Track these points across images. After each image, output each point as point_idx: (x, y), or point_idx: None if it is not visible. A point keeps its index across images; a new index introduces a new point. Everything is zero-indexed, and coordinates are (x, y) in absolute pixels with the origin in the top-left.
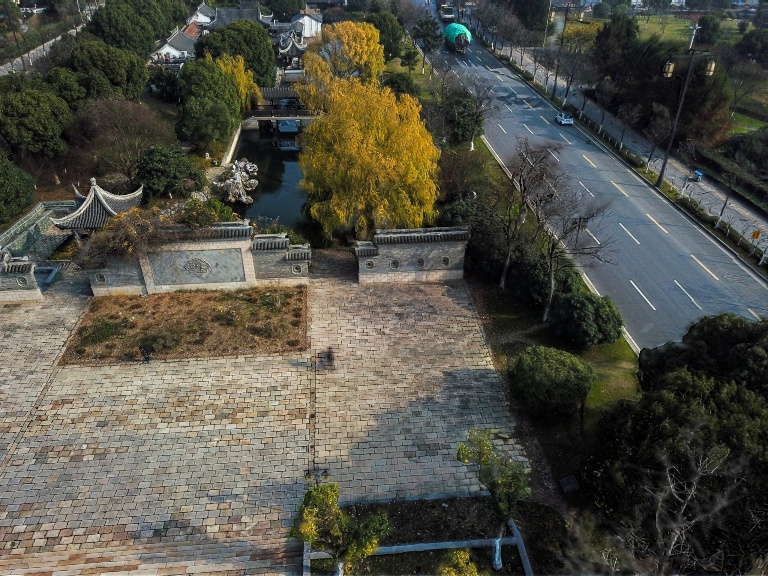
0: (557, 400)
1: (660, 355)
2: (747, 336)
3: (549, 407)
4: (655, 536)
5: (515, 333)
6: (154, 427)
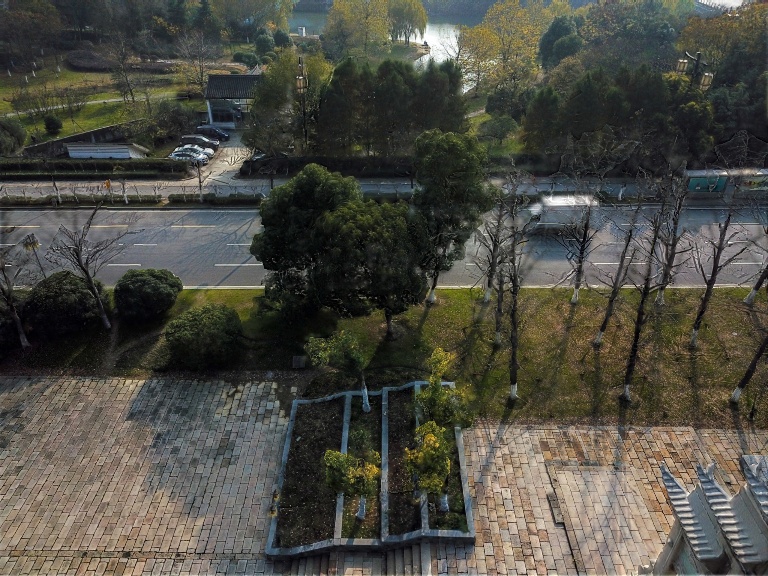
0: (235, 332)
1: (273, 238)
2: (309, 186)
3: (233, 343)
4: (419, 283)
5: (110, 352)
6: None
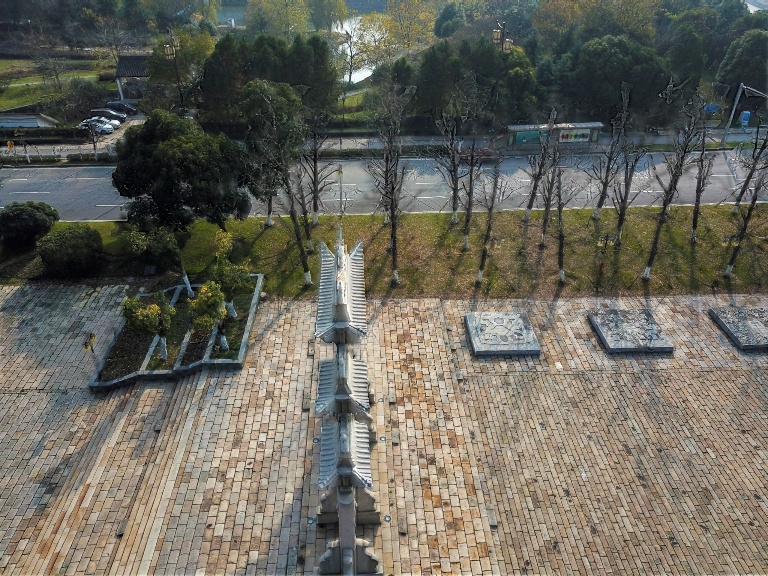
0: (94, 246)
1: (124, 169)
2: (153, 126)
3: (93, 255)
4: (231, 195)
5: None
6: None
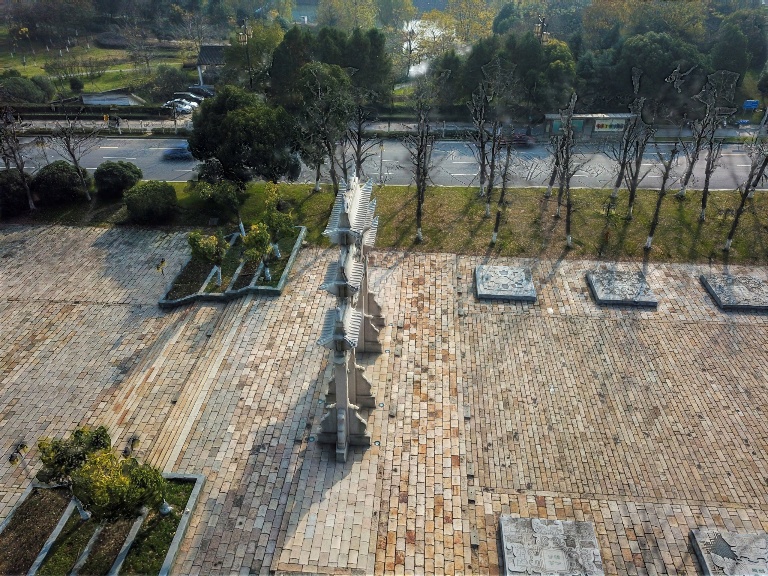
0: (169, 198)
1: (197, 134)
2: (223, 99)
3: (168, 206)
4: (283, 158)
5: (88, 213)
6: (3, 385)
